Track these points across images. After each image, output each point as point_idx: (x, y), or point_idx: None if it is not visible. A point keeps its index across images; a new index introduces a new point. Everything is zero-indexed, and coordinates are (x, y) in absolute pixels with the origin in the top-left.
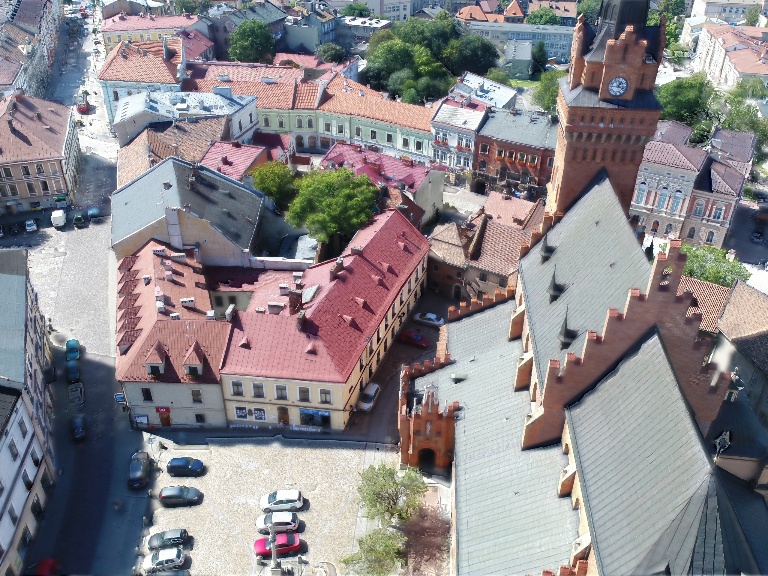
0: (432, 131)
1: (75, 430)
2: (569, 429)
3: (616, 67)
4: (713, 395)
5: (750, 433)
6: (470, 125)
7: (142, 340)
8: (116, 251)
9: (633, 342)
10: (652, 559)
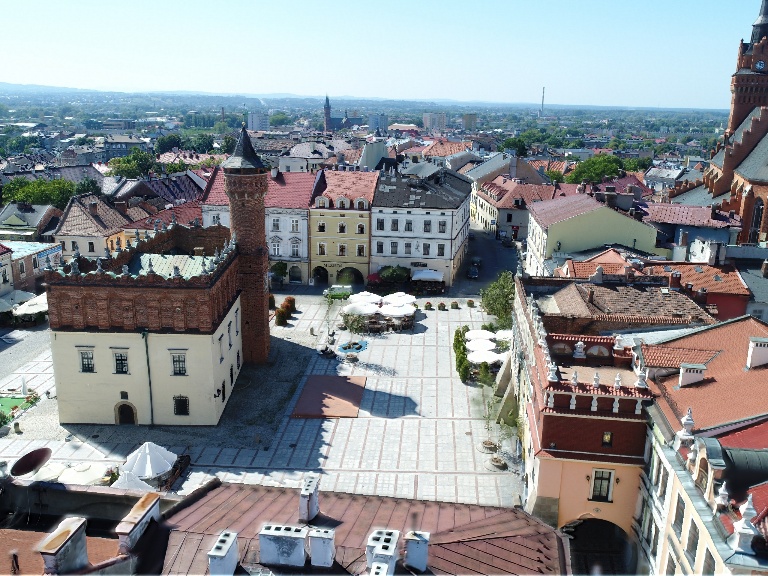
0: (644, 183)
1: (471, 234)
2: (735, 171)
3: (759, 56)
4: None
5: None
6: (672, 176)
7: (510, 192)
8: (478, 182)
9: (764, 133)
10: (767, 161)
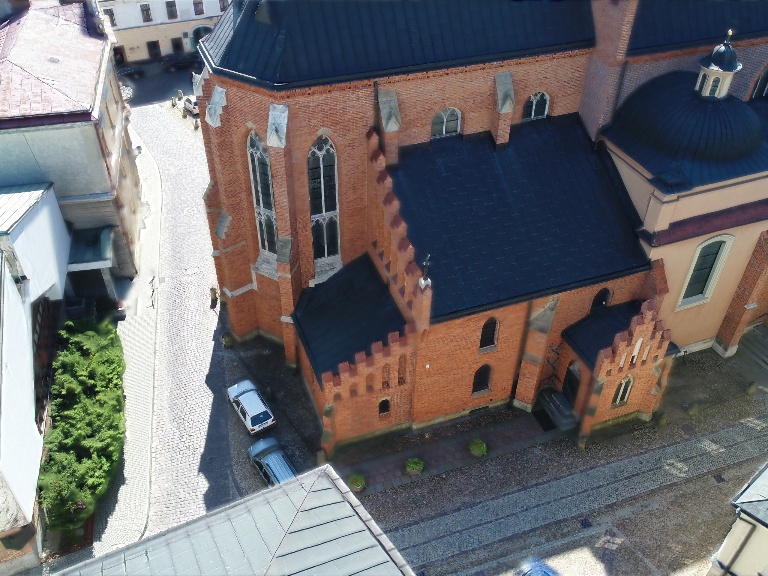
0: None
1: None
2: None
3: None
4: (615, 8)
5: (677, 140)
6: None
7: None
8: None
9: None
10: None
